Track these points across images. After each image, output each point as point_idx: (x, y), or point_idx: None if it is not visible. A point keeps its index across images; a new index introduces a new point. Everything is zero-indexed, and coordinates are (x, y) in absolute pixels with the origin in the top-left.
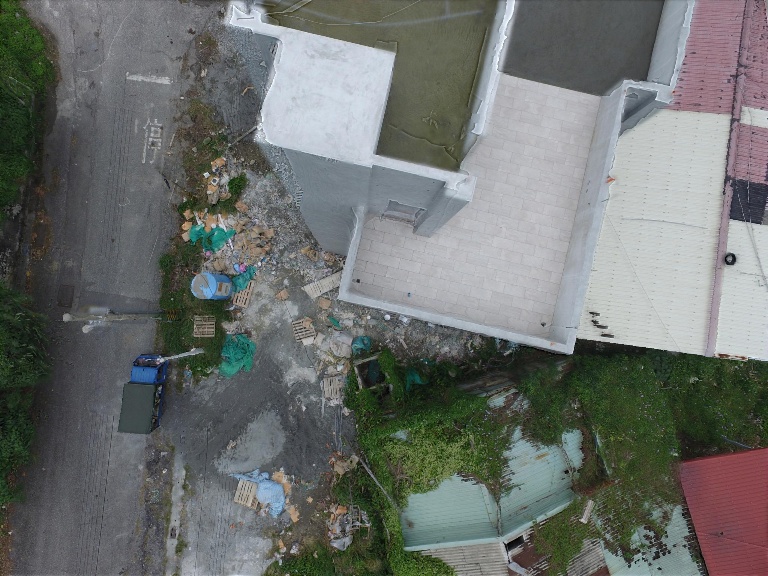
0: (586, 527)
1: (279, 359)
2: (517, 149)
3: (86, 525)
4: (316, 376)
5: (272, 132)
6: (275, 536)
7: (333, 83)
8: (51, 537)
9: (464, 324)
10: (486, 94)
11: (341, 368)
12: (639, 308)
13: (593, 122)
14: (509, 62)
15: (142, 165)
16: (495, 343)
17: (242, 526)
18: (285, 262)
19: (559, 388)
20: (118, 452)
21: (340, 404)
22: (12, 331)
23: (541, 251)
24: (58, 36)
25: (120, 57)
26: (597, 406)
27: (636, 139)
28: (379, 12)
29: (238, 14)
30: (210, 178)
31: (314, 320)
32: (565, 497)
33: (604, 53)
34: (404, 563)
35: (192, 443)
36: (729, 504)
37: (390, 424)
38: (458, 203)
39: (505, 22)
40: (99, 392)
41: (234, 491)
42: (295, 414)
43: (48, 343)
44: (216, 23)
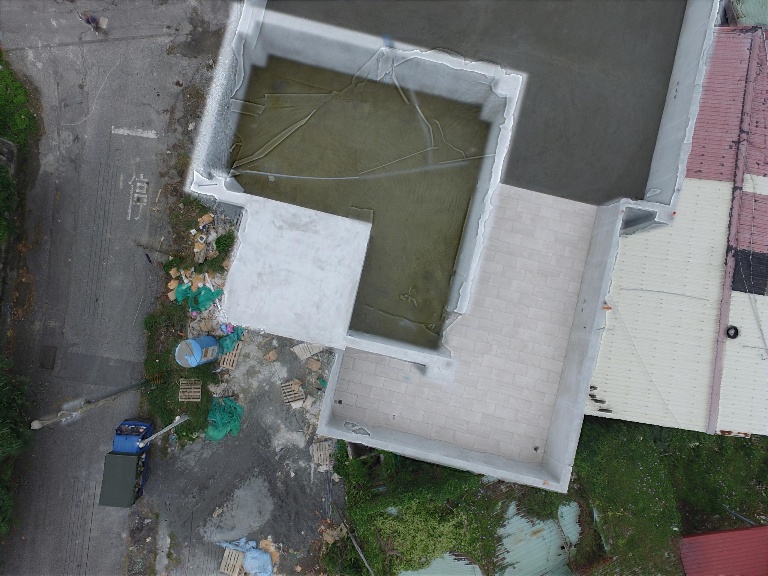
0: None
1: (267, 423)
2: (509, 261)
3: None
4: (305, 441)
5: (236, 312)
6: None
7: (303, 258)
8: None
9: (451, 461)
10: (470, 269)
11: None
12: (638, 382)
13: (589, 233)
14: None
15: (127, 222)
16: None
17: None
18: None
19: None
20: (100, 520)
21: (330, 470)
22: None
23: (534, 371)
24: (42, 88)
25: (105, 110)
26: (594, 480)
27: None
28: (356, 164)
29: (199, 180)
30: (197, 235)
31: (303, 382)
32: (561, 575)
33: (601, 160)
34: None
35: (177, 510)
36: None
37: (380, 501)
38: None
39: (491, 191)
40: (81, 458)
41: (220, 560)
42: (283, 480)
43: (29, 406)
44: (204, 75)
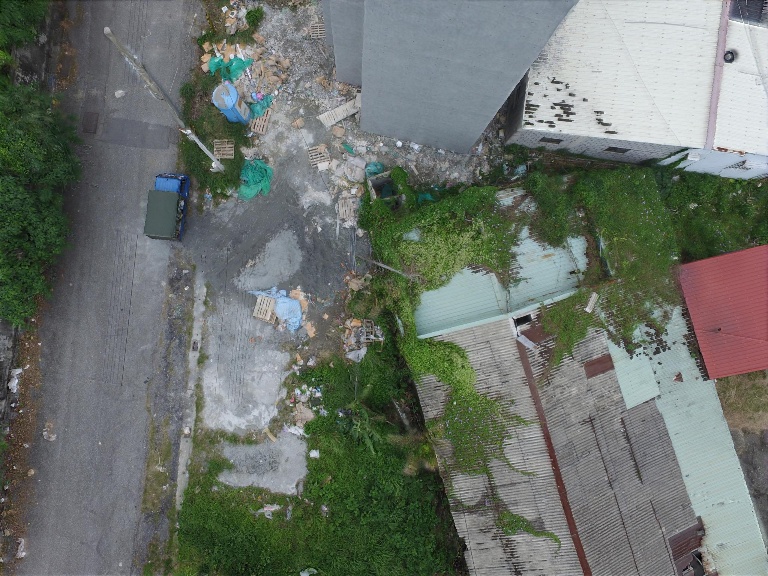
0: (590, 316)
1: (295, 184)
2: None
3: (112, 336)
4: (331, 199)
5: None
6: (292, 350)
7: None
8: (79, 347)
9: None
10: None
11: (355, 190)
12: (641, 105)
13: None
14: None
15: None
16: (503, 168)
17: (261, 340)
18: (301, 92)
19: (565, 194)
20: (142, 269)
21: (354, 226)
22: (45, 120)
23: None
24: None
25: None
26: (601, 209)
27: None
28: None
29: None
30: (228, 12)
31: (329, 147)
32: None
33: None
34: (417, 348)
35: (212, 262)
36: (726, 301)
37: (404, 218)
38: None
39: None
40: (123, 212)
41: (253, 308)
42: (311, 236)
43: (74, 167)
44: None
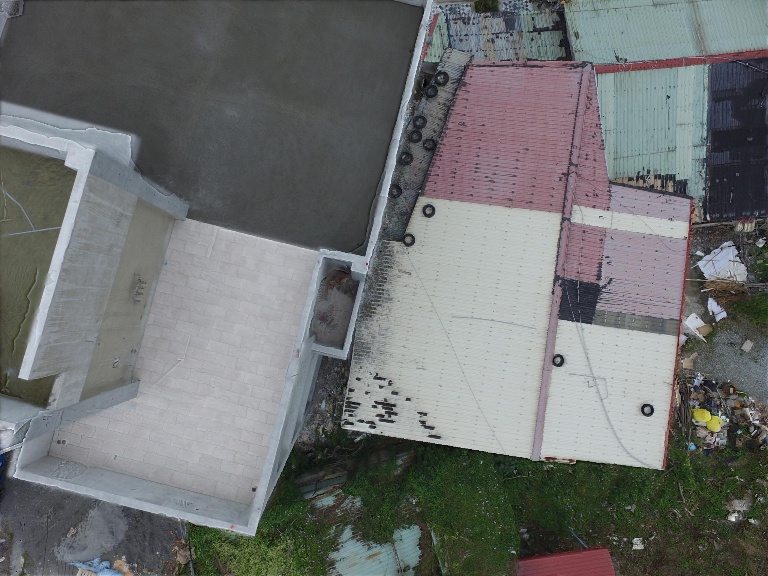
0: None
1: None
2: (233, 306)
3: None
4: None
5: None
6: None
7: None
8: None
9: (143, 504)
10: (35, 337)
11: None
12: (466, 409)
13: None
14: (227, 216)
15: None
16: None
17: None
18: None
19: (394, 484)
20: None
21: None
22: None
23: (254, 413)
24: None
25: None
26: (431, 504)
27: (468, 235)
28: None
29: None
30: None
31: None
32: None
33: (326, 207)
34: None
35: (32, 530)
36: None
37: None
38: (169, 362)
39: (57, 262)
40: None
41: None
42: None
43: None
44: None
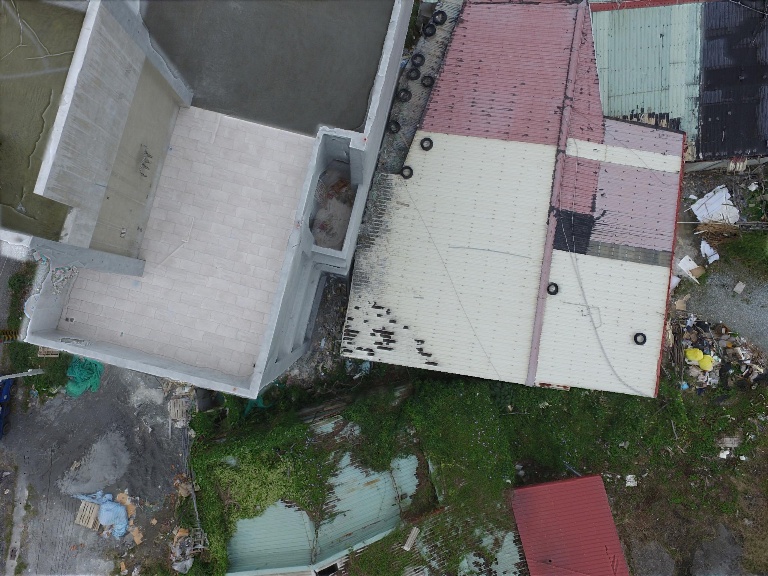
0: (408, 554)
1: (128, 380)
2: (236, 190)
3: None
4: (164, 397)
5: None
6: (117, 558)
7: None
8: None
9: (149, 368)
10: (50, 155)
11: (188, 390)
12: (462, 336)
13: None
14: (230, 104)
15: None
16: (344, 366)
17: (83, 548)
18: None
19: (392, 414)
20: None
21: (187, 426)
22: None
23: (255, 292)
24: None
25: None
26: (428, 432)
27: (465, 168)
28: None
29: None
30: None
31: None
32: (391, 524)
33: (325, 96)
34: None
35: (36, 464)
36: (557, 532)
37: (214, 449)
38: (173, 243)
39: (70, 84)
40: None
41: (77, 512)
42: (142, 435)
43: None
44: None
